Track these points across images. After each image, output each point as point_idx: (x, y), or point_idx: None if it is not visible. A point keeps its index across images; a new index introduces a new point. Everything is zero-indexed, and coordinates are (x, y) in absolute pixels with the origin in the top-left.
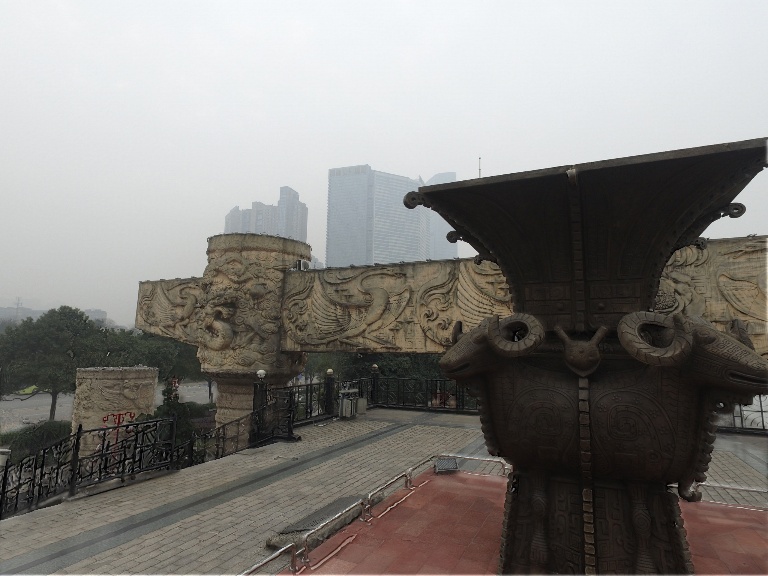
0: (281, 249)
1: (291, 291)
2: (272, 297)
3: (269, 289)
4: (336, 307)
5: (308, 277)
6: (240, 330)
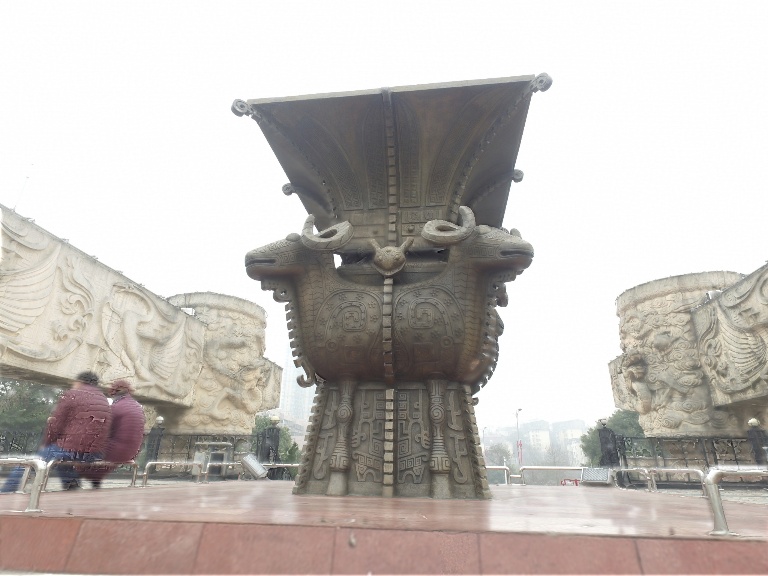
0: (677, 289)
1: (701, 332)
2: (681, 344)
3: (674, 336)
4: (745, 335)
5: (710, 309)
6: (656, 388)
